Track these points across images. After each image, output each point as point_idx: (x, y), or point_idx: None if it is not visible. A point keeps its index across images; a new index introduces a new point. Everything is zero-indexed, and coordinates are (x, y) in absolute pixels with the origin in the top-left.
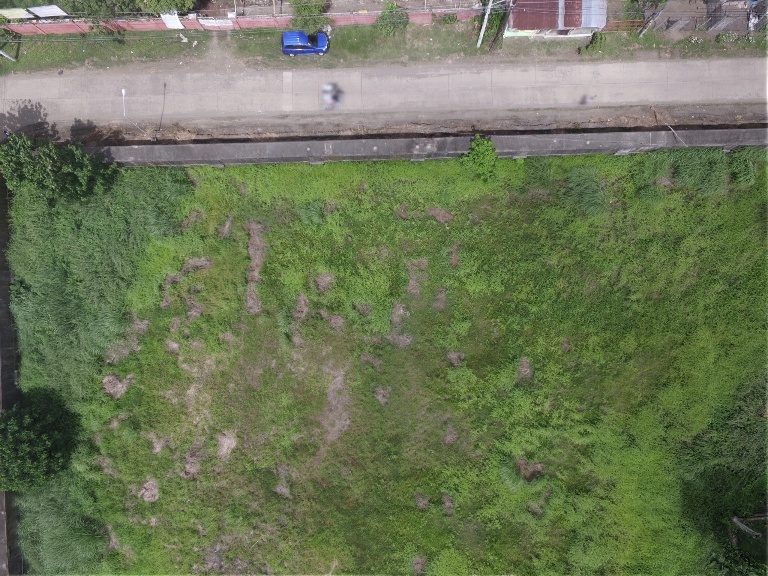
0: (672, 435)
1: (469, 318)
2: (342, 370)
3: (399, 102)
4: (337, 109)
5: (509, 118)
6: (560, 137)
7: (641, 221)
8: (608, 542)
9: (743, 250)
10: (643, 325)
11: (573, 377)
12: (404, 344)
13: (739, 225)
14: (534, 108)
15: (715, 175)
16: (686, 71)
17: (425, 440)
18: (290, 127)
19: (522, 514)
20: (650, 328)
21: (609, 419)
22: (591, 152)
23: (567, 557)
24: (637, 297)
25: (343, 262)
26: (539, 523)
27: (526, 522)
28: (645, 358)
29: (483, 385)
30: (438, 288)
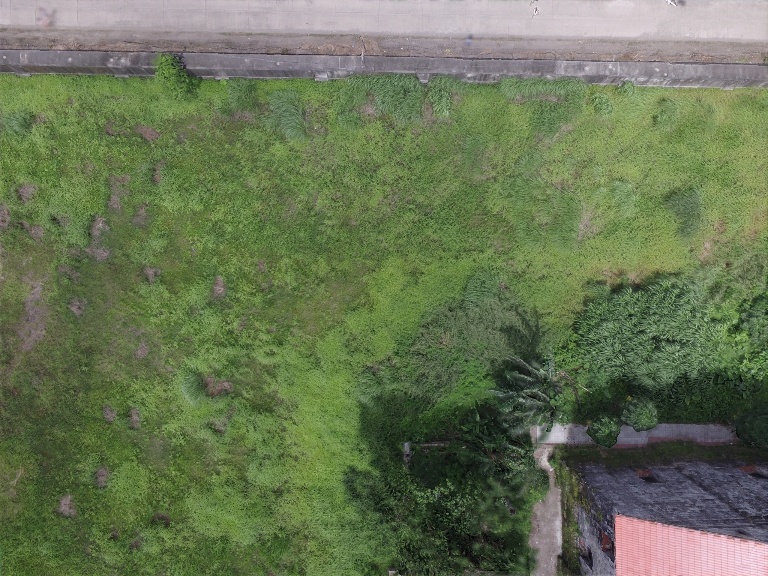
0: (357, 359)
1: (167, 235)
2: (40, 281)
3: (114, 21)
4: (54, 25)
5: (221, 41)
6: (250, 56)
7: (341, 147)
8: (287, 462)
9: (440, 181)
10: (336, 249)
11: (266, 298)
12: (101, 257)
13: (437, 156)
14: (246, 33)
15: (408, 103)
16: (398, 4)
17: (118, 354)
18: (7, 40)
19: (202, 430)
20: (343, 253)
21: (297, 341)
22: (291, 76)
23: (247, 476)
24: (333, 222)
25: (47, 174)
26: (220, 440)
27: (207, 438)
28: (338, 283)
29: (176, 302)
30: (139, 204)
